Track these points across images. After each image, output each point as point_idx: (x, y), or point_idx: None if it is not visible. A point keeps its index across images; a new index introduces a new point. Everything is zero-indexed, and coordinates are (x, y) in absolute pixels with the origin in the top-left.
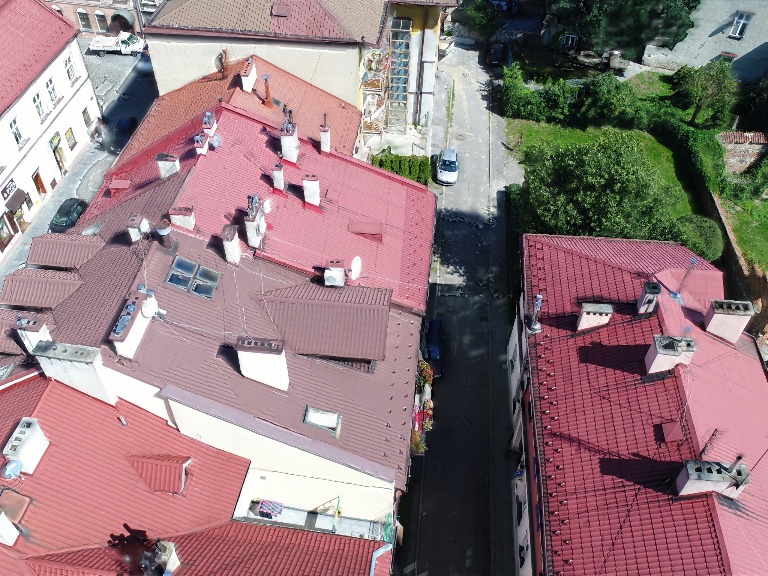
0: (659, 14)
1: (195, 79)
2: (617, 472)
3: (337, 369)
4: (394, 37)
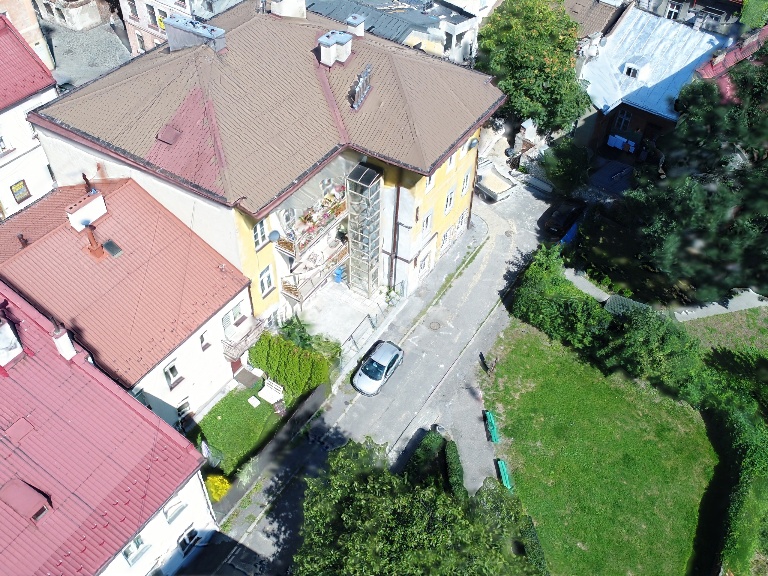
0: (765, 256)
1: (84, 182)
2: None
3: None
4: (353, 187)
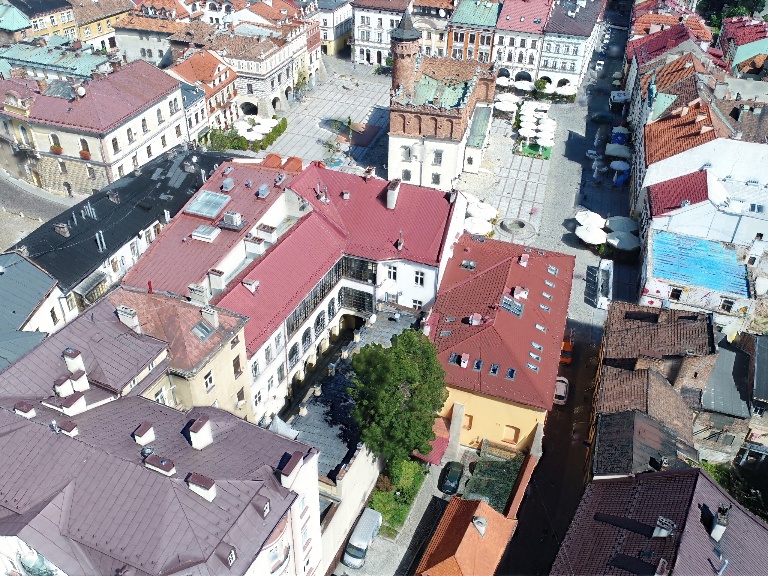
0: (756, 1)
1: (645, 1)
2: None
3: None
4: None
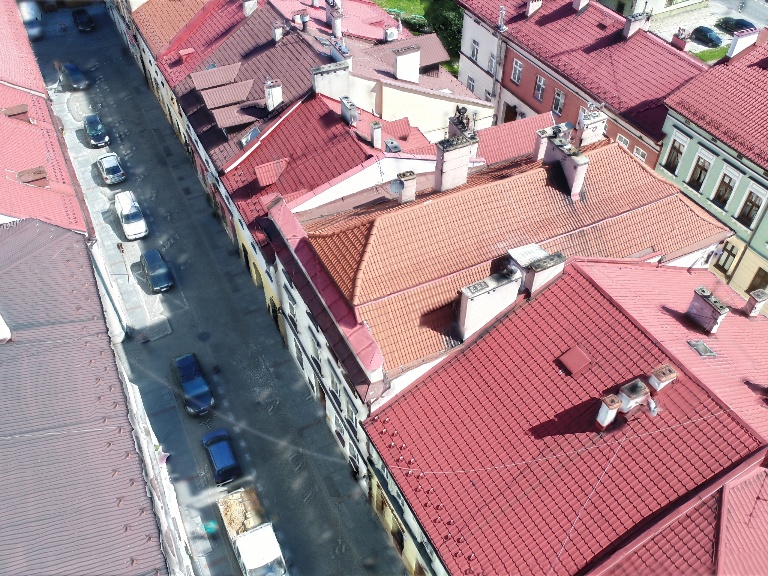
0: None
1: None
2: (594, 49)
3: (425, 77)
4: None
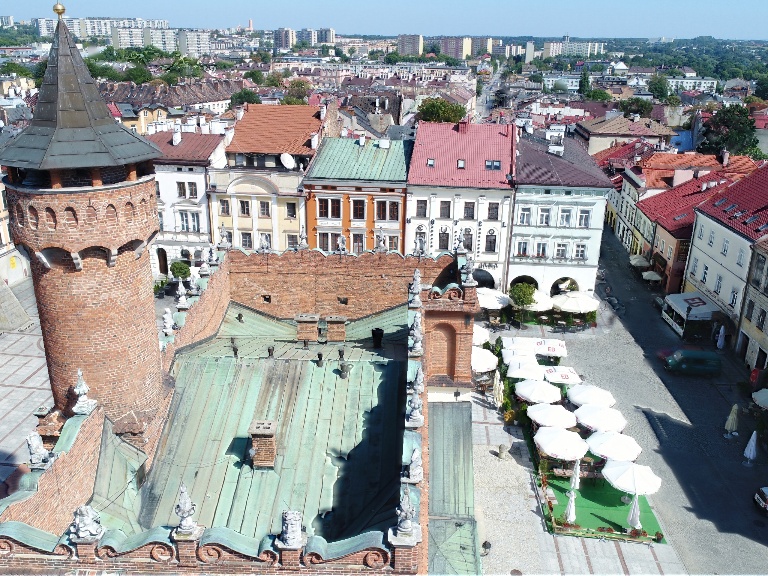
0: (745, 146)
1: (602, 150)
2: None
3: None
4: None
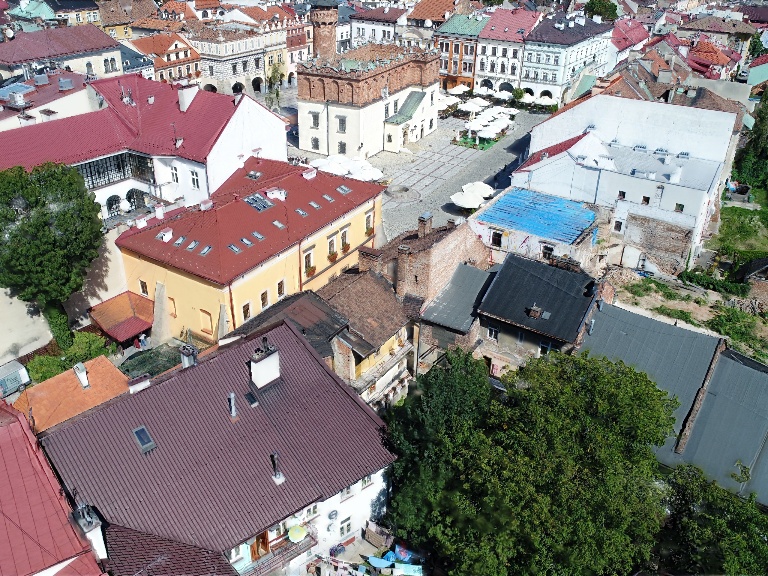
0: None
1: None
2: None
3: None
4: (736, 41)
